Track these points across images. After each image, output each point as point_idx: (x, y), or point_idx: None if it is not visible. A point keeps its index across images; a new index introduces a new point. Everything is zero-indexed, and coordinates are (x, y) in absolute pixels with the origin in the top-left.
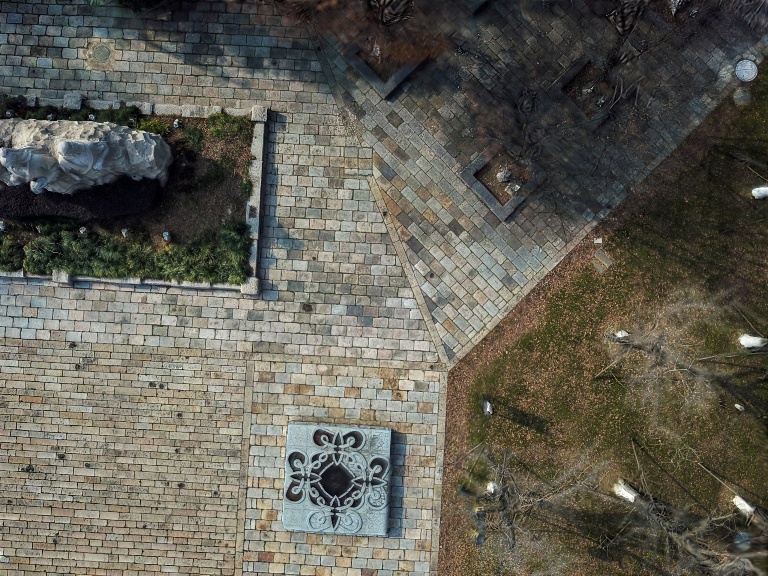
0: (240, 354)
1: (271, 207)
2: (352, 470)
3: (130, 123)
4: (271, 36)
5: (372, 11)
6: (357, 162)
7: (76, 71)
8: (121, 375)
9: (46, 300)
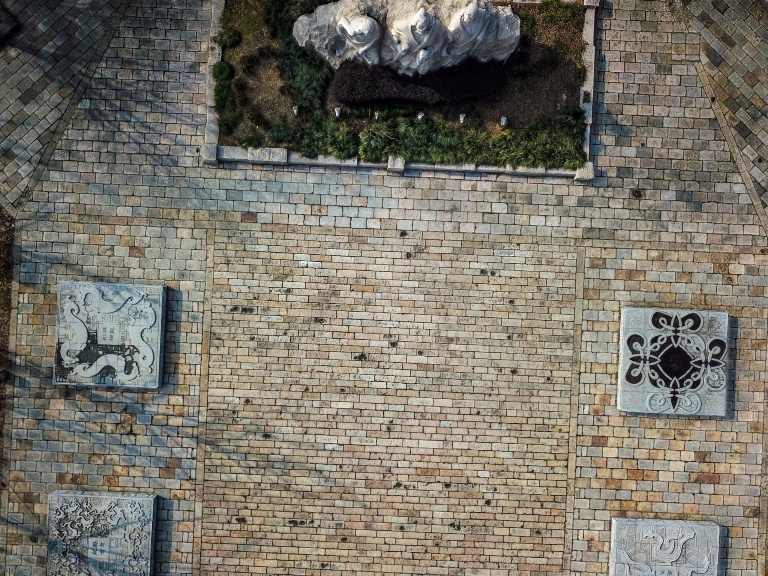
0: (571, 240)
1: (599, 94)
2: (690, 352)
3: None
4: None
5: None
6: (685, 48)
7: None
8: (452, 263)
9: (375, 189)
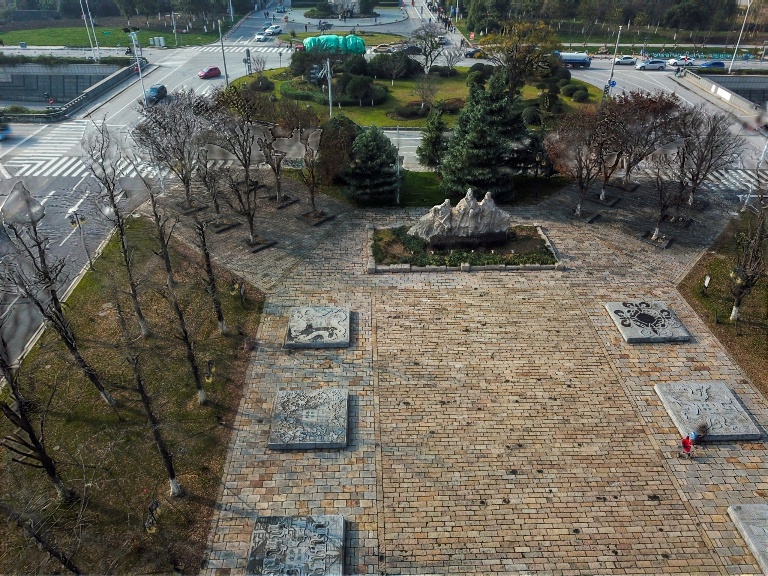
0: None
1: None
2: (652, 315)
3: None
4: (530, 212)
5: (581, 182)
6: None
7: None
8: None
9: (457, 277)
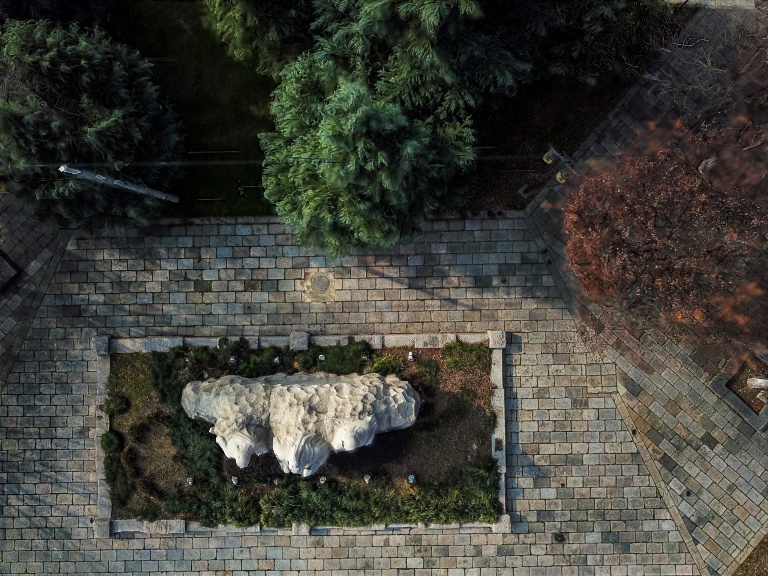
0: None
1: (513, 434)
2: None
3: (363, 361)
4: (498, 252)
5: None
6: (600, 380)
7: (294, 304)
8: None
9: (282, 550)
